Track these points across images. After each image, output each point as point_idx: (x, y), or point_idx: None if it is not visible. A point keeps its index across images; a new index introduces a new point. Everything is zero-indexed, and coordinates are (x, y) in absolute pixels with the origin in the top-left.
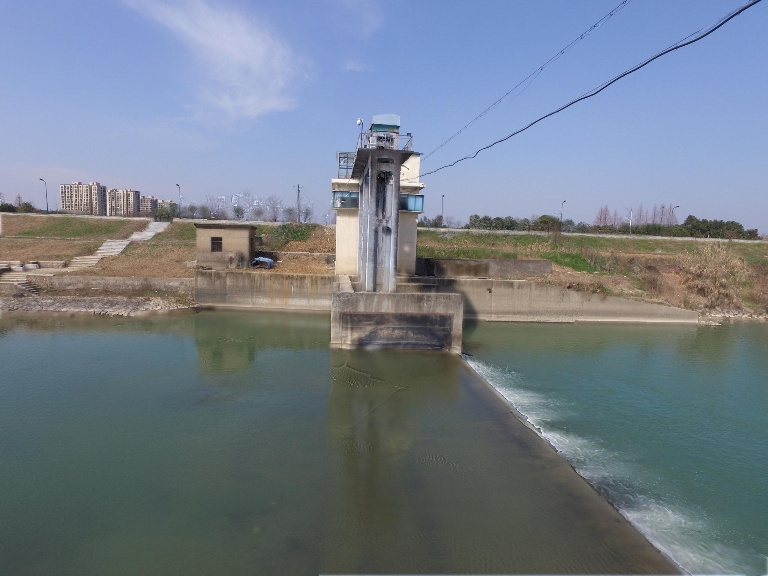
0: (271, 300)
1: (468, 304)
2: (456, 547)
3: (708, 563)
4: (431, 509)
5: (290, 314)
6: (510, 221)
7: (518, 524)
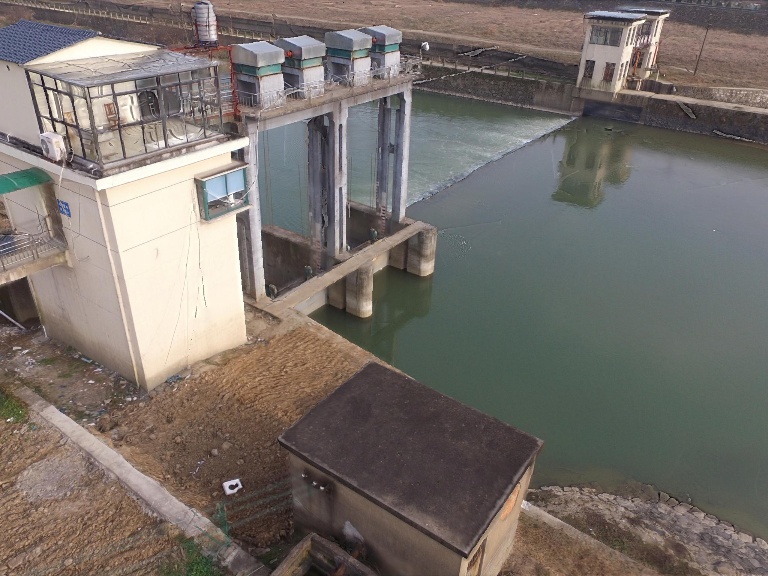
0: None
1: None
2: (508, 192)
3: None
4: (504, 197)
5: None
6: None
7: (486, 190)
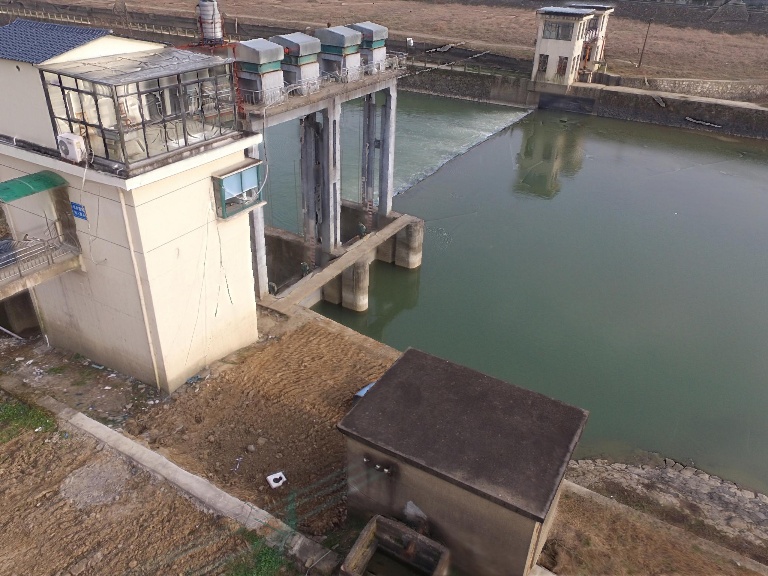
0: None
1: None
2: (479, 184)
3: None
4: (476, 189)
5: None
6: None
7: None
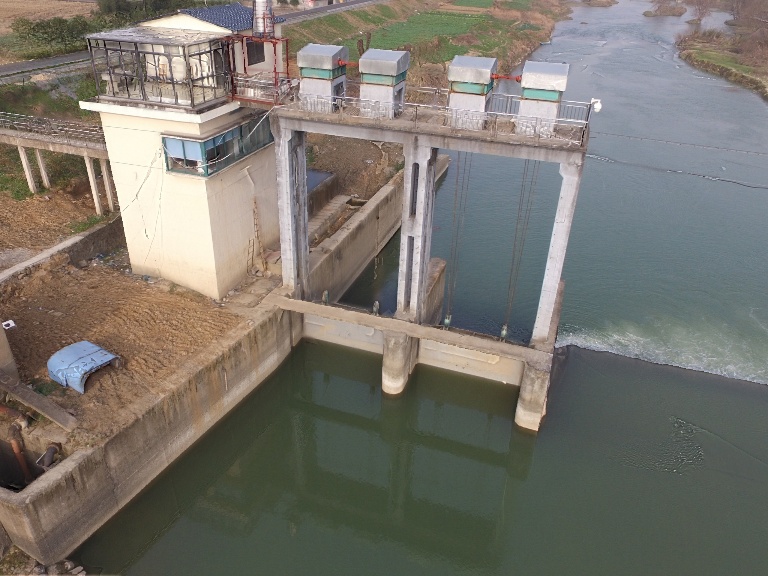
0: (197, 424)
1: (367, 248)
2: None
3: None
4: None
5: (229, 421)
6: (83, 24)
7: None
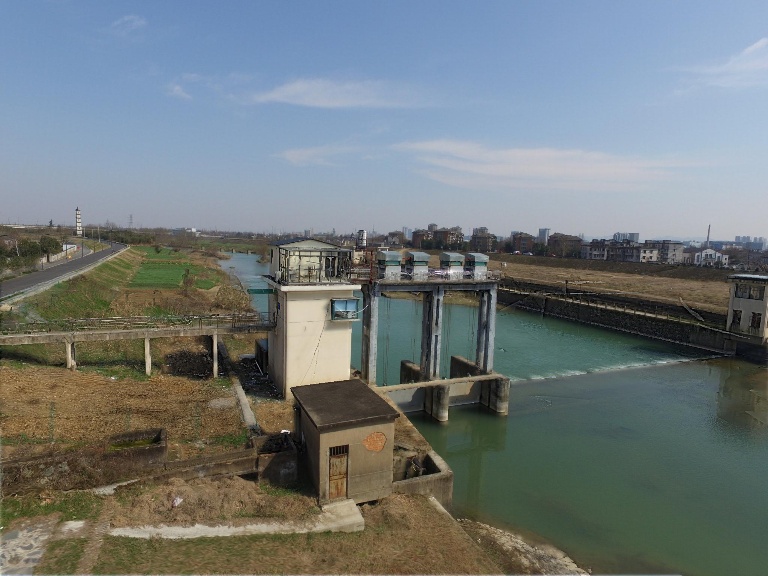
0: None
1: None
2: None
3: (577, 373)
4: None
5: None
6: None
7: None
